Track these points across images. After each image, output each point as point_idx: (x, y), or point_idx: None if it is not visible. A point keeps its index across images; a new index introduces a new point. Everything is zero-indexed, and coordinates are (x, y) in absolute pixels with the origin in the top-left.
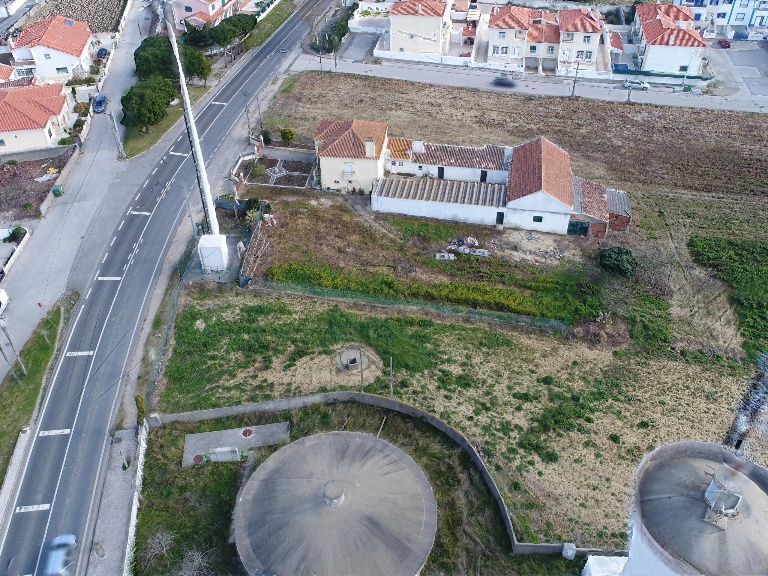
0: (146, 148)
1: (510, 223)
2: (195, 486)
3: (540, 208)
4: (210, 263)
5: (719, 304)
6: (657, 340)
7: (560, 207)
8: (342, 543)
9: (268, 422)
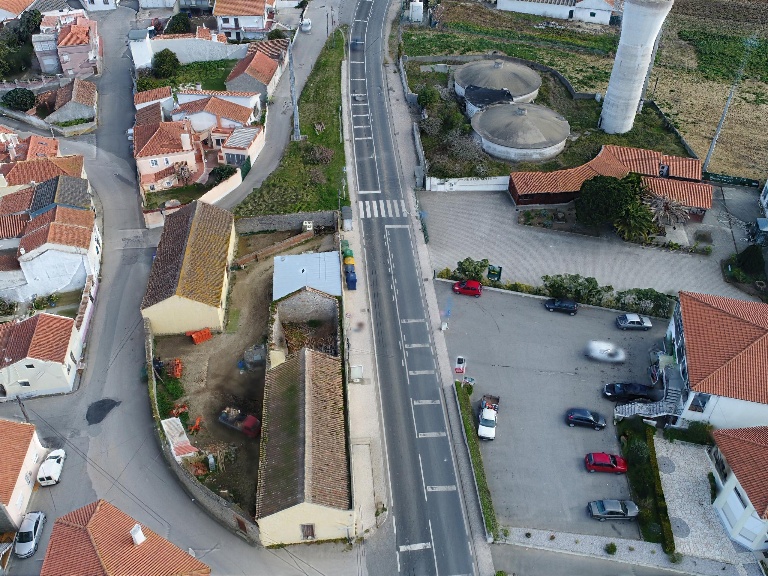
0: None
1: (577, 17)
2: (430, 76)
3: (595, 7)
4: (415, 16)
5: (689, 52)
6: None
7: (606, 6)
8: (503, 78)
9: (458, 64)
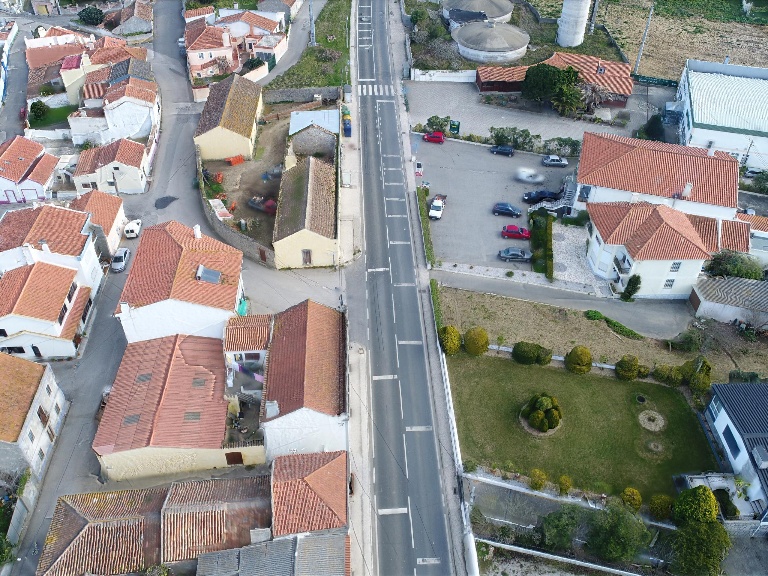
0: None
1: None
2: (424, 5)
3: None
4: None
5: None
6: (614, 1)
7: None
8: (482, 3)
9: None
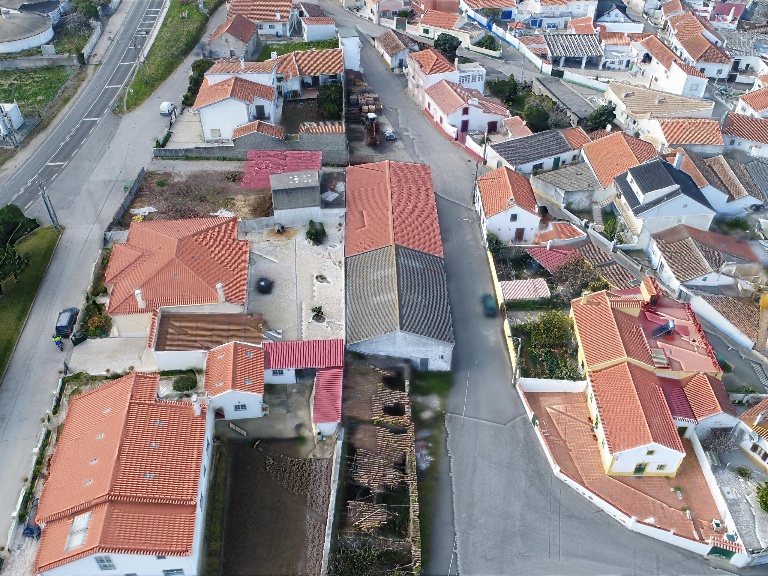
0: (29, 237)
1: None
2: None
3: None
4: None
5: None
6: None
7: None
8: None
9: None
